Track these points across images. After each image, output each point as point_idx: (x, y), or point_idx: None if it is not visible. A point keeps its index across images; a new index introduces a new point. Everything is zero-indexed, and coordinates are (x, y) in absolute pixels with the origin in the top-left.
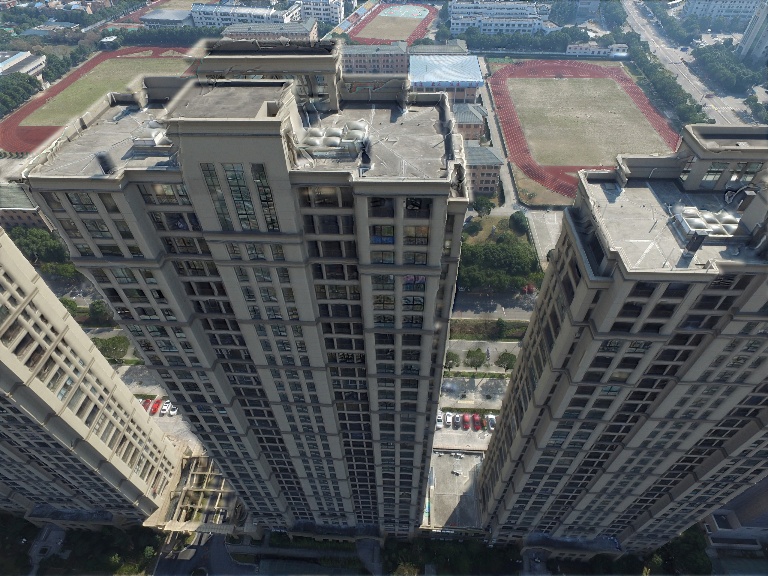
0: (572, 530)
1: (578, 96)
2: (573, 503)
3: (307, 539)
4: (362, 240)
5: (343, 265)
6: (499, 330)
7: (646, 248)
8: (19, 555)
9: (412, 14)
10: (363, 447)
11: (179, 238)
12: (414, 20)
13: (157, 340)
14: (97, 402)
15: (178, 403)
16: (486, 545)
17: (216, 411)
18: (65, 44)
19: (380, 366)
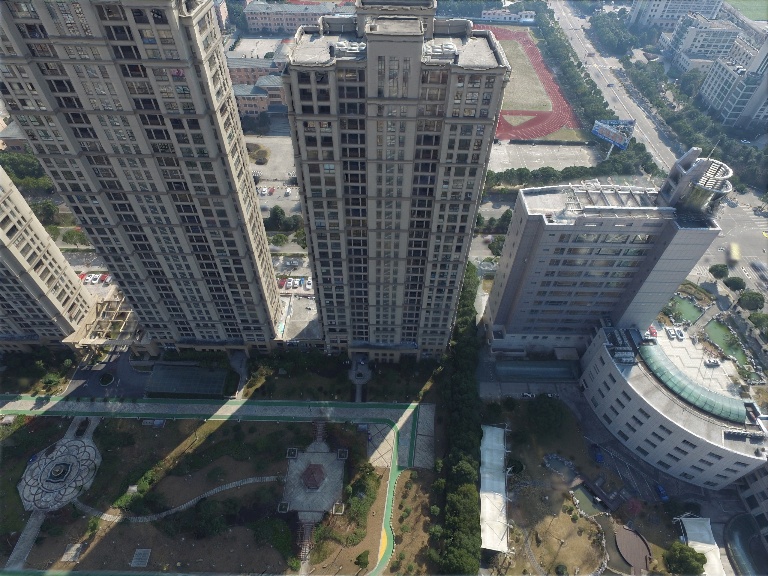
0: (379, 332)
1: None
2: (368, 300)
3: (190, 350)
4: (138, 40)
5: (138, 65)
6: None
7: (311, 57)
8: None
9: None
10: (204, 242)
11: (38, 44)
12: None
13: (38, 130)
14: (16, 224)
15: (63, 193)
16: (326, 354)
17: (90, 200)
18: None
19: (183, 150)
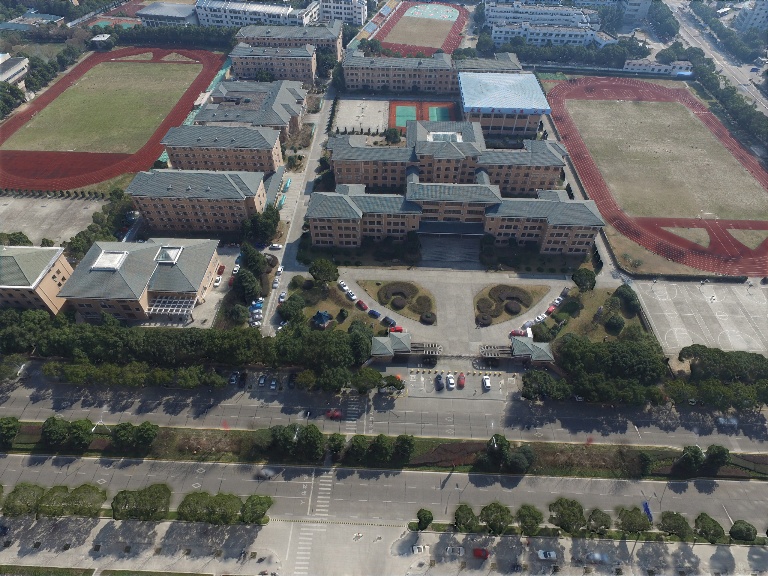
0: None
1: (649, 124)
2: None
3: None
4: None
5: None
6: (643, 465)
7: None
8: None
9: (441, 15)
10: None
11: None
12: (445, 23)
13: None
14: None
15: None
16: None
17: None
18: (49, 41)
19: None
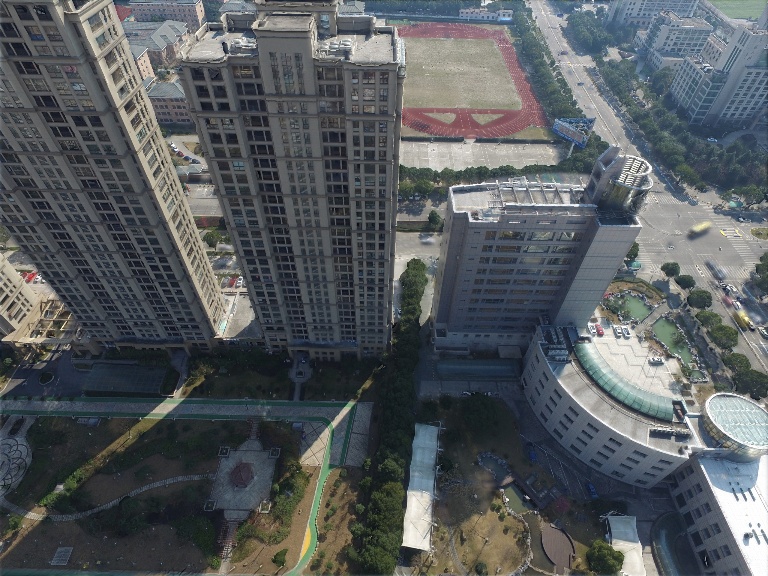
0: (318, 330)
1: (457, 53)
2: (301, 298)
3: (130, 348)
4: (25, 37)
5: (32, 62)
6: None
7: (207, 54)
8: None
9: None
10: (128, 240)
11: None
12: None
13: None
14: None
15: None
16: (268, 353)
17: (6, 198)
18: None
19: (90, 148)
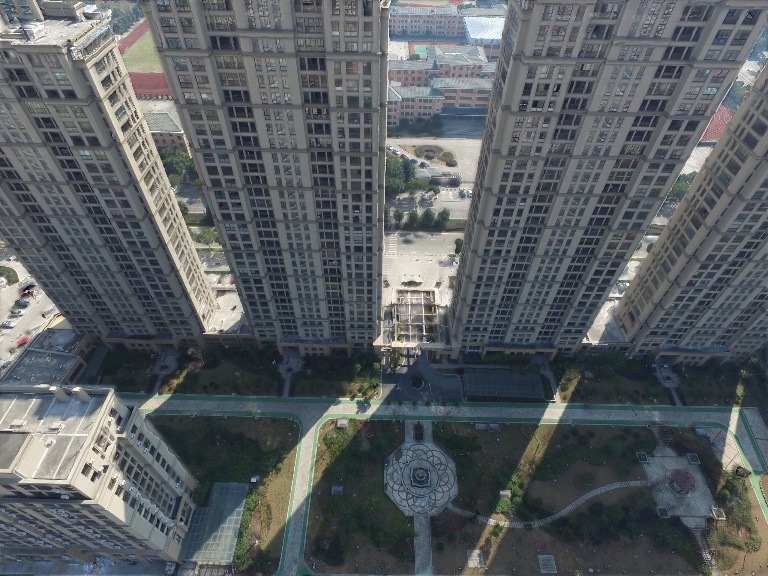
0: (698, 335)
1: None
2: (711, 303)
3: (498, 353)
4: (709, 41)
5: (677, 66)
6: None
7: None
8: (272, 373)
9: None
10: (591, 245)
11: (591, 45)
12: None
13: (526, 131)
14: None
15: (497, 195)
16: (627, 358)
17: (519, 203)
18: (117, 1)
19: (657, 152)
